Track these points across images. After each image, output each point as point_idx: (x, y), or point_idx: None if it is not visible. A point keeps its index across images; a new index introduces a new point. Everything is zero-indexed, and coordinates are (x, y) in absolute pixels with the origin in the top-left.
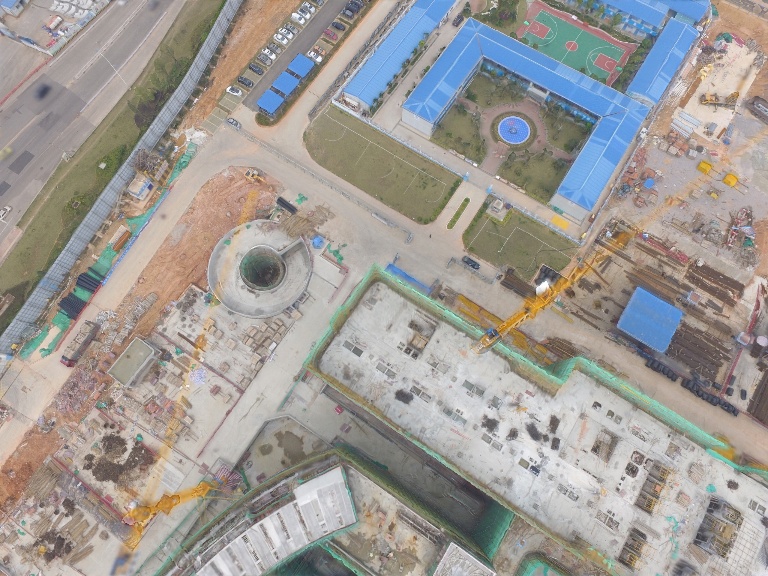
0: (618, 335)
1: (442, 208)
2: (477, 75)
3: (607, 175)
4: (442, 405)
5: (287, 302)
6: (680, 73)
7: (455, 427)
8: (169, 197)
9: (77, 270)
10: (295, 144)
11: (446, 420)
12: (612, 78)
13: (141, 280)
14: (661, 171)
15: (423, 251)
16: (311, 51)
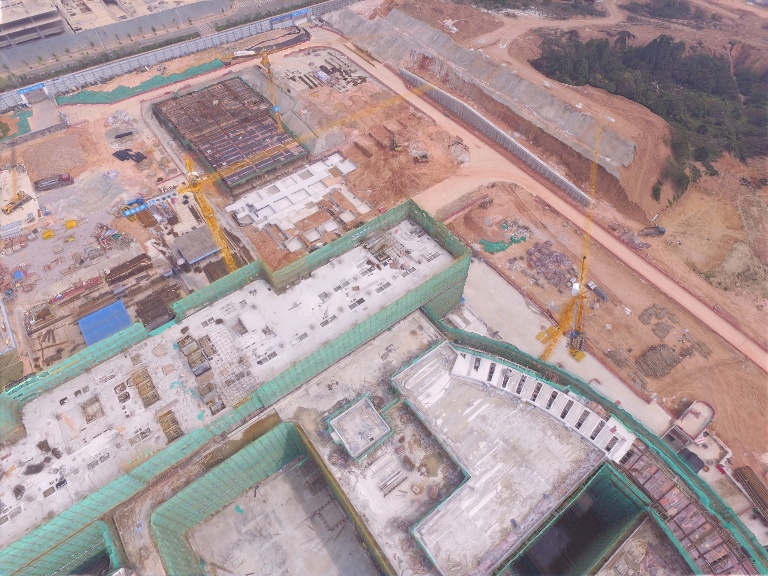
0: None
1: None
2: None
3: None
4: None
5: None
6: None
7: None
8: None
9: None
10: None
11: None
12: None
13: None
14: (24, 262)
15: None
16: None
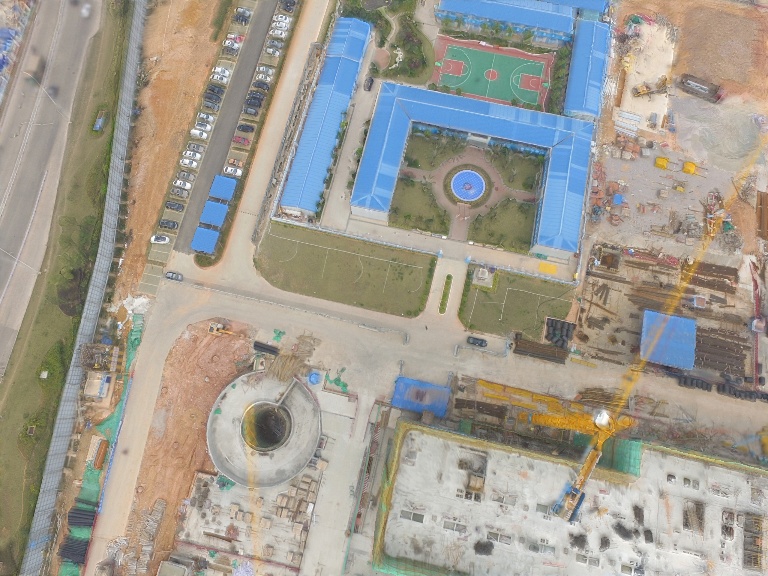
0: (644, 365)
1: (427, 294)
2: (409, 138)
3: (579, 209)
4: (525, 542)
5: (305, 450)
6: (604, 72)
7: (546, 560)
8: (134, 384)
9: (62, 504)
10: (249, 276)
11: (535, 556)
12: (542, 97)
13: (139, 489)
14: (623, 180)
15: (425, 346)
16: (227, 167)
